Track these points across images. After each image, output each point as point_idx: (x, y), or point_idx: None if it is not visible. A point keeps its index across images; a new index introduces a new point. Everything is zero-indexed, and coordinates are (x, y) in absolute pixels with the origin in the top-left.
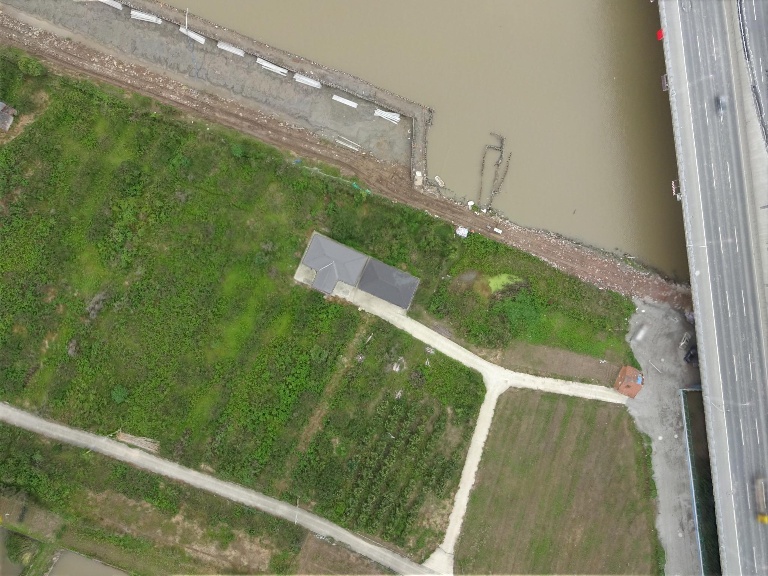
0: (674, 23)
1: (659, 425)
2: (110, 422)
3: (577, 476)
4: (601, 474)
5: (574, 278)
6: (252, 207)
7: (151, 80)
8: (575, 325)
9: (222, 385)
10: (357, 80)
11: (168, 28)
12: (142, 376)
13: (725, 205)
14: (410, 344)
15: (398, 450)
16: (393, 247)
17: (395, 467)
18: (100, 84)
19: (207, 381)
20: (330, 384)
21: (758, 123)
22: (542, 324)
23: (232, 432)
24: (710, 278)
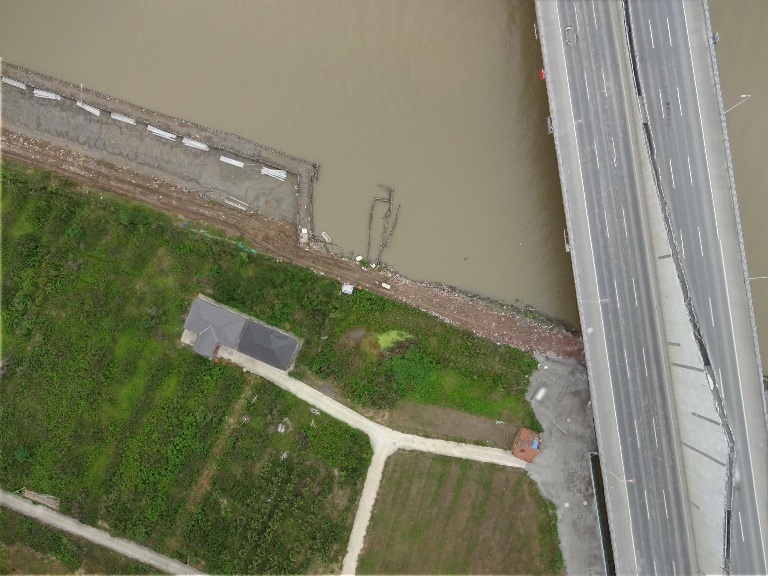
0: (557, 60)
1: (565, 491)
2: (15, 480)
3: (473, 543)
4: (499, 542)
5: (468, 334)
6: (140, 272)
7: (52, 154)
8: (468, 384)
9: (115, 445)
10: (242, 140)
11: (66, 103)
12: (43, 437)
13: (621, 255)
14: (294, 405)
15: (284, 512)
16: (275, 307)
17: (282, 529)
18: (5, 162)
19: (101, 442)
20: (217, 445)
21: (649, 165)
22: (431, 383)
23: (125, 491)
24: (605, 335)
